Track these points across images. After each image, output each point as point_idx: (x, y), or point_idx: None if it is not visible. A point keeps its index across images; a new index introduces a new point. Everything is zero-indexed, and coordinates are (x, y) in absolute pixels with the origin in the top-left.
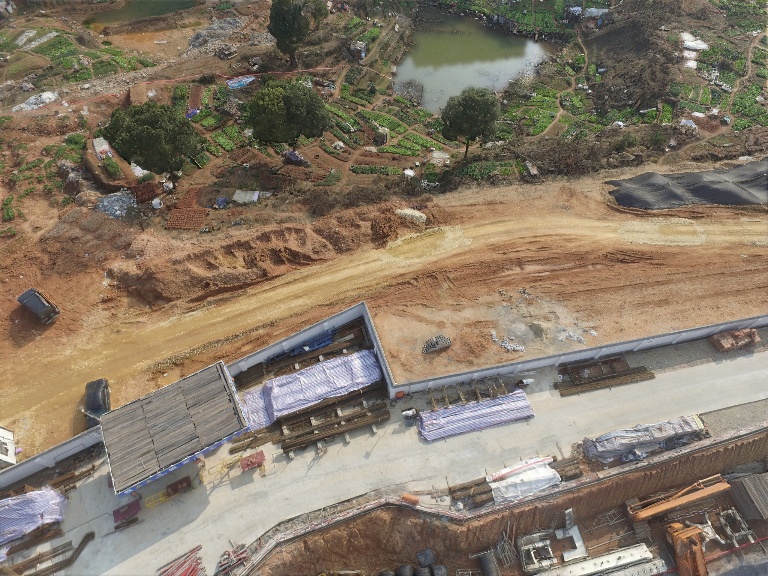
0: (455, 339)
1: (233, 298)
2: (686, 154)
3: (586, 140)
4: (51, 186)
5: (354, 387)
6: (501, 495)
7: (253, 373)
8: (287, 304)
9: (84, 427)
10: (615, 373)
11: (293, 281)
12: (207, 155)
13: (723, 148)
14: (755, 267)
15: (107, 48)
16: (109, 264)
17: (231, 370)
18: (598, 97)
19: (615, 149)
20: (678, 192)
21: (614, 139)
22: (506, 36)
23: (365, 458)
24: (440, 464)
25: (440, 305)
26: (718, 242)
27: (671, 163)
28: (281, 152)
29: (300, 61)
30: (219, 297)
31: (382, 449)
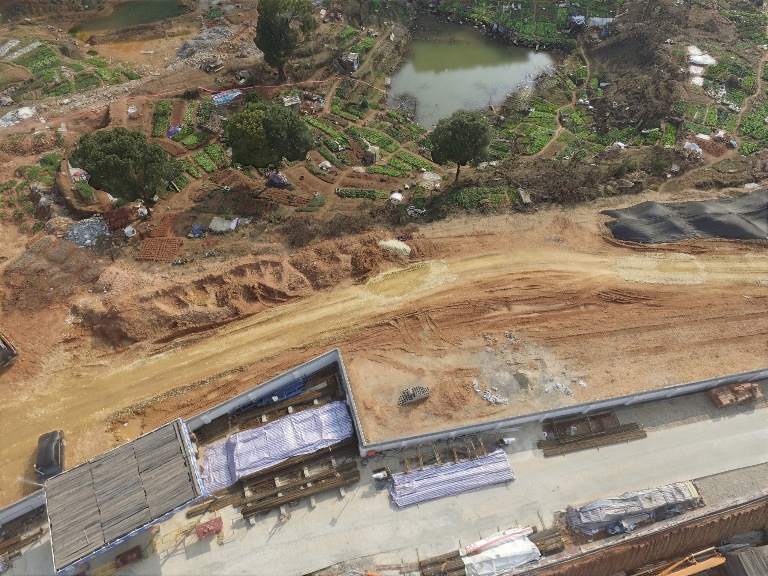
0: (434, 389)
1: (202, 339)
2: (689, 181)
3: (584, 162)
4: (22, 210)
5: (323, 444)
6: (475, 572)
7: (217, 426)
8: (258, 347)
9: (35, 484)
10: (604, 431)
11: (266, 321)
12: (186, 177)
13: (728, 174)
14: (759, 310)
15: (92, 59)
16: (74, 299)
17: (192, 424)
18: (599, 114)
19: (614, 174)
20: (678, 224)
21: (614, 162)
22: (506, 46)
23: (331, 525)
24: (411, 534)
25: (420, 350)
26: (720, 281)
27: (672, 191)
28: (264, 173)
29: (289, 74)
30: (187, 338)
31: (349, 515)
